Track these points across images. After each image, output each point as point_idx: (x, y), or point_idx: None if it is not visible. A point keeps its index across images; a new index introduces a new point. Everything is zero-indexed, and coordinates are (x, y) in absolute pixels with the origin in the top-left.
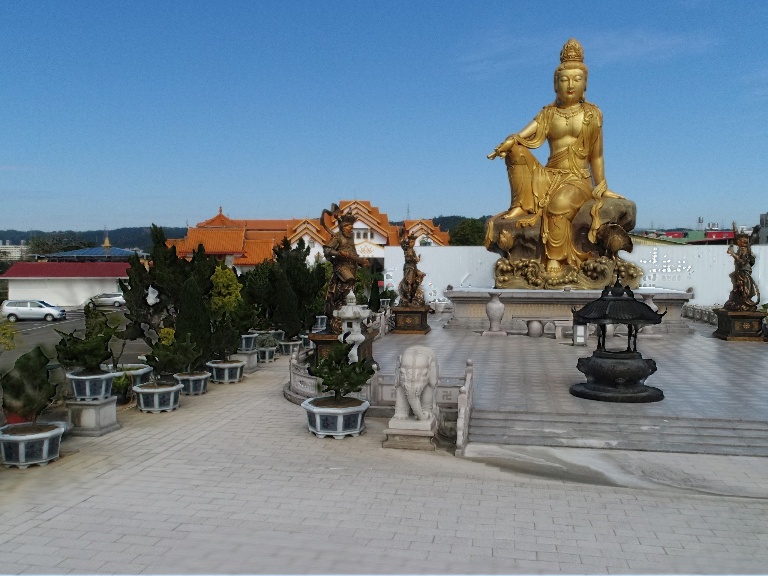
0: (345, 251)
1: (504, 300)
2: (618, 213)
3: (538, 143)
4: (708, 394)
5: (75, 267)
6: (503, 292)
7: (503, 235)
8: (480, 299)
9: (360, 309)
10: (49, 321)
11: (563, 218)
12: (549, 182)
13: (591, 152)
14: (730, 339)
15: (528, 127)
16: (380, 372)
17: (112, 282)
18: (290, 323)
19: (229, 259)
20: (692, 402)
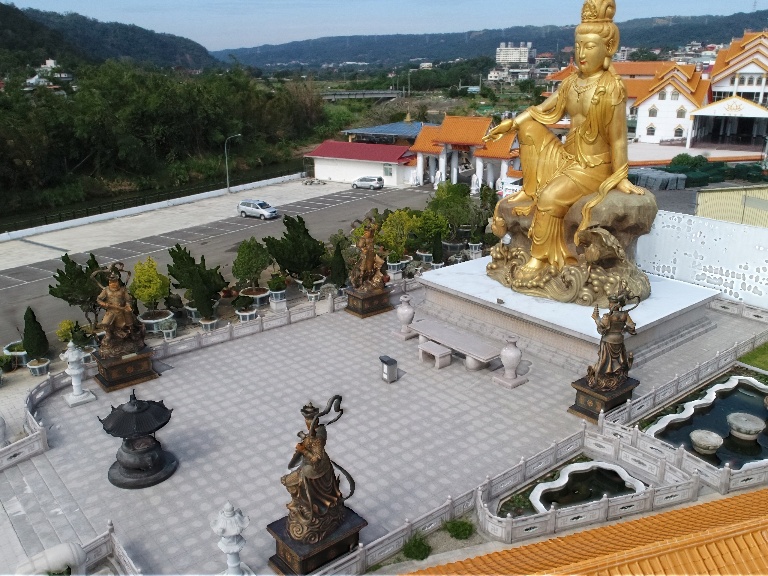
0: (109, 301)
1: (455, 296)
2: (613, 215)
3: (555, 118)
4: (187, 495)
5: (360, 148)
6: (451, 289)
7: (495, 222)
8: (438, 290)
9: (73, 355)
10: (262, 220)
11: (545, 215)
12: (556, 166)
13: (607, 134)
14: (570, 411)
15: (550, 98)
16: (147, 382)
17: (379, 165)
18: (199, 309)
19: (472, 149)
20: (143, 500)
